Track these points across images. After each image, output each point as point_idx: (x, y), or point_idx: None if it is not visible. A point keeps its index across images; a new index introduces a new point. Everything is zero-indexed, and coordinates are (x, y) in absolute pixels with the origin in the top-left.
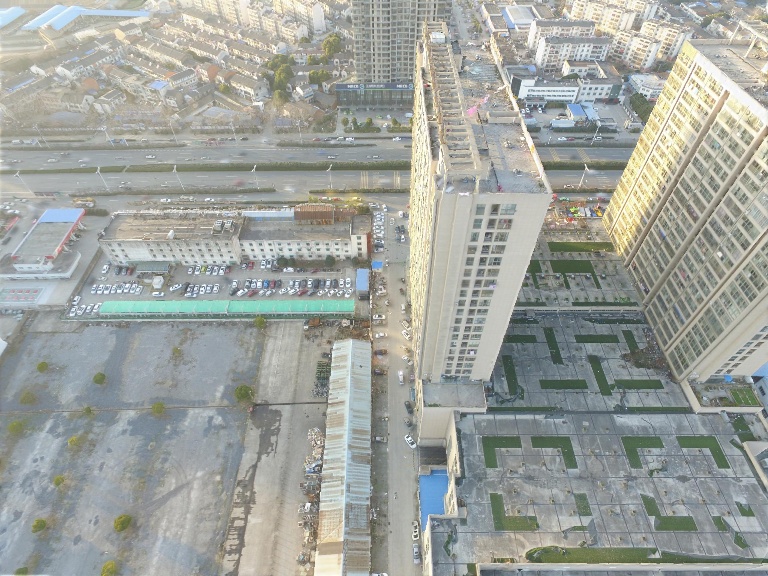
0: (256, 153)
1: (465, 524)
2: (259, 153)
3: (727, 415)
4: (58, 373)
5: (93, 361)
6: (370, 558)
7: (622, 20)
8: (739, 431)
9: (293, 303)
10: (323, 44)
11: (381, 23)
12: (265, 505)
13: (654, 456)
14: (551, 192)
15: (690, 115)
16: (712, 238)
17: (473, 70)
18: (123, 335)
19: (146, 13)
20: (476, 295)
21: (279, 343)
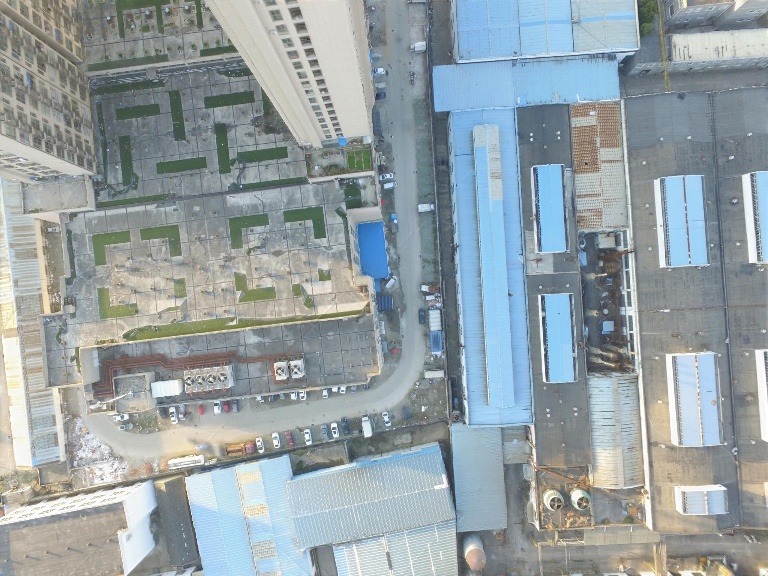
0: None
1: (74, 317)
2: None
3: (338, 183)
4: None
5: None
6: None
7: None
8: (348, 198)
9: None
10: None
11: None
12: None
13: (256, 234)
14: None
15: None
16: None
17: None
18: None
19: None
20: None
21: None
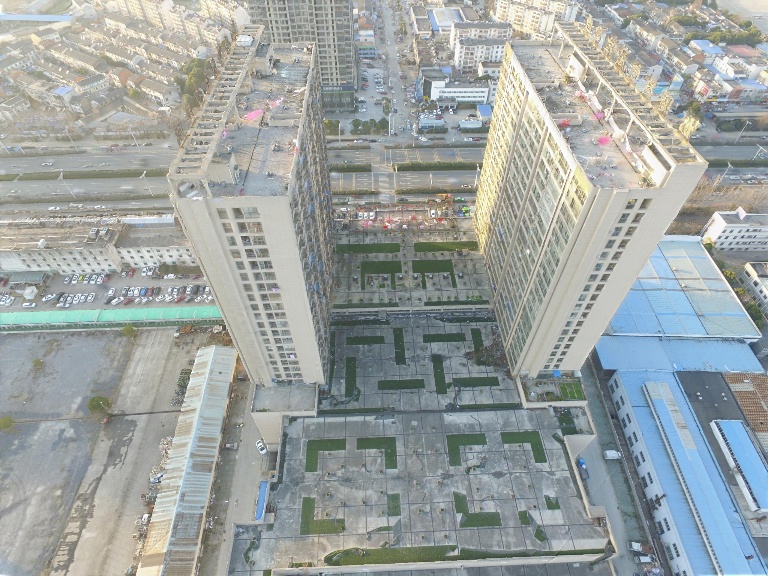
0: (158, 159)
1: (271, 530)
2: (161, 158)
3: (553, 409)
4: None
5: None
6: (198, 568)
7: (541, 22)
8: (563, 425)
9: (166, 310)
10: None
11: (280, 26)
12: (102, 518)
13: (475, 453)
14: (286, 195)
15: (510, 115)
16: (524, 236)
17: (284, 73)
18: None
19: (68, 18)
20: (267, 299)
21: (147, 351)
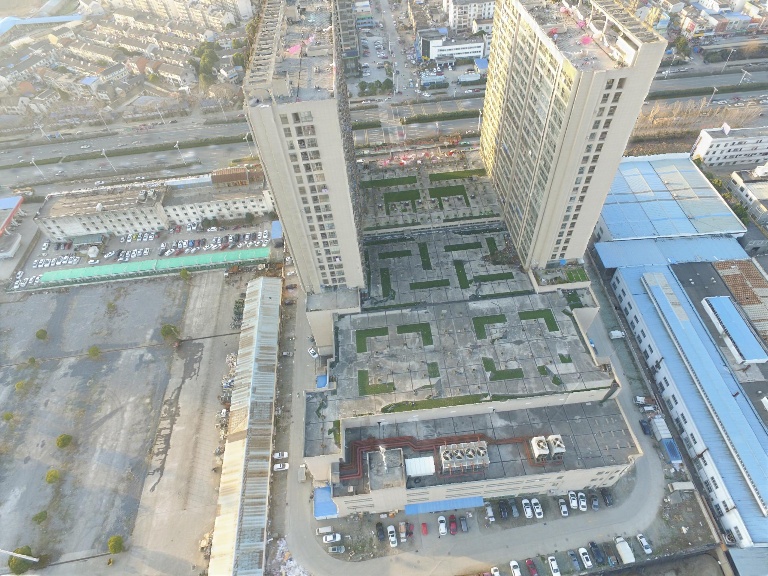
0: (184, 133)
1: (335, 394)
2: (187, 133)
3: (561, 291)
4: (6, 335)
5: (37, 322)
6: (274, 443)
7: None
8: (571, 303)
9: (214, 255)
10: (246, 28)
11: None
12: (188, 416)
13: (497, 329)
14: (334, 98)
15: (506, 40)
16: (525, 140)
17: (310, 19)
18: (63, 299)
19: (79, 17)
20: (317, 202)
21: (203, 290)
